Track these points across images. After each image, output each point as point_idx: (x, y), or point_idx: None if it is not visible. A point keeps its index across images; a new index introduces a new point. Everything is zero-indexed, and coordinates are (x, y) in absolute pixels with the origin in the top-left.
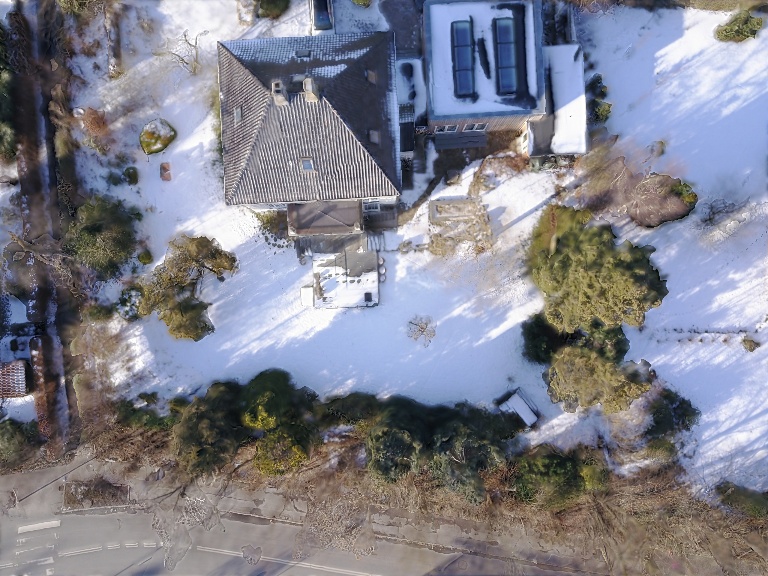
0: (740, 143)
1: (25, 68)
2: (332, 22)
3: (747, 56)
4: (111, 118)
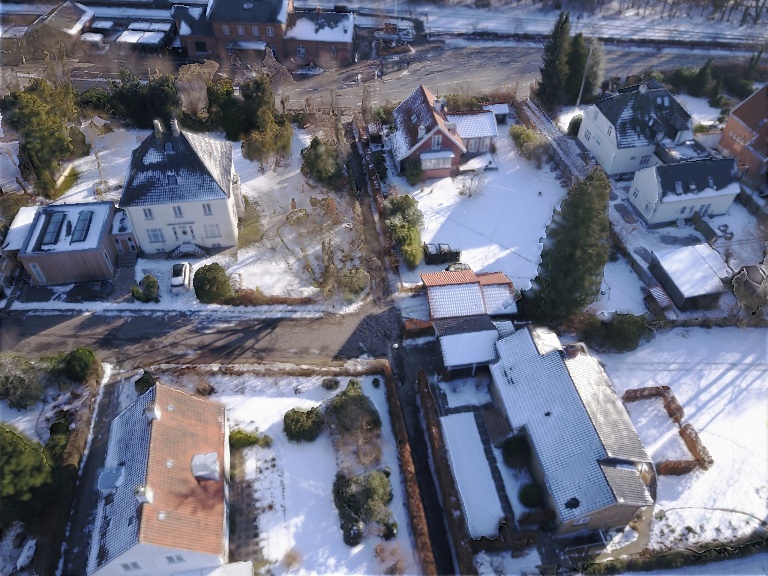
0: None
1: None
2: None
3: None
4: (329, 226)
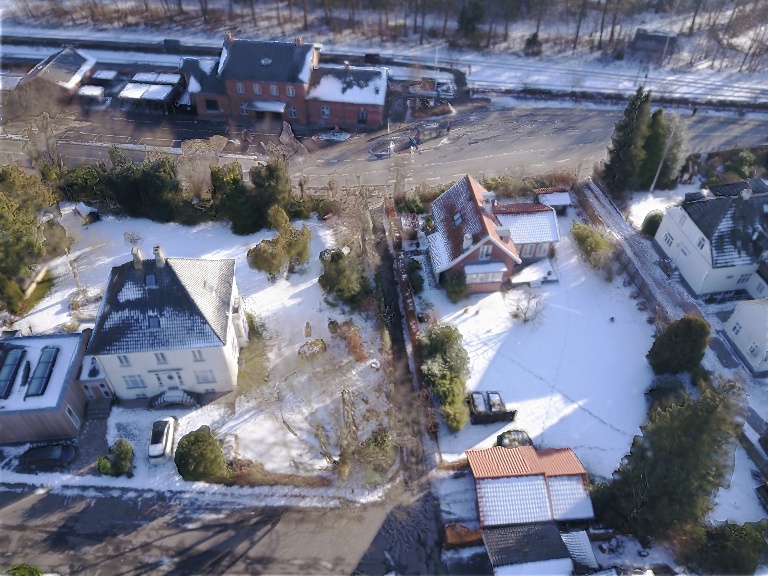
0: None
1: None
2: None
3: None
4: (351, 364)
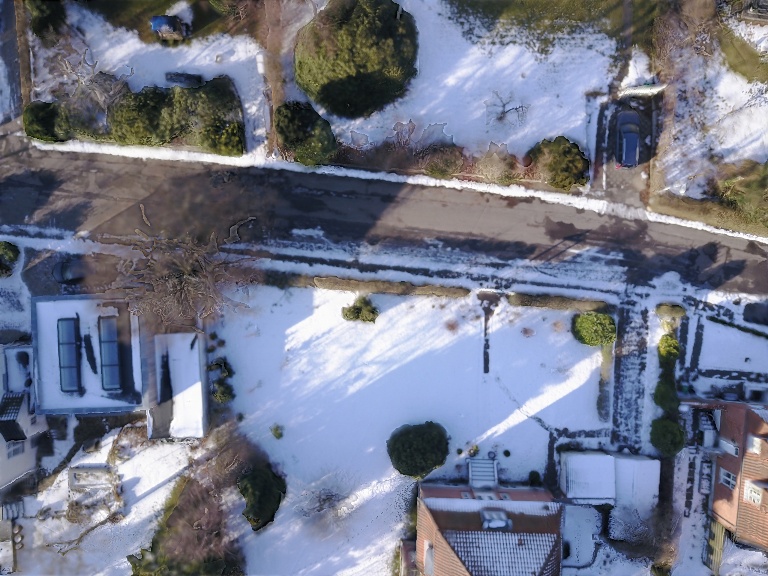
0: (365, 420)
1: None
2: None
3: (373, 335)
4: None
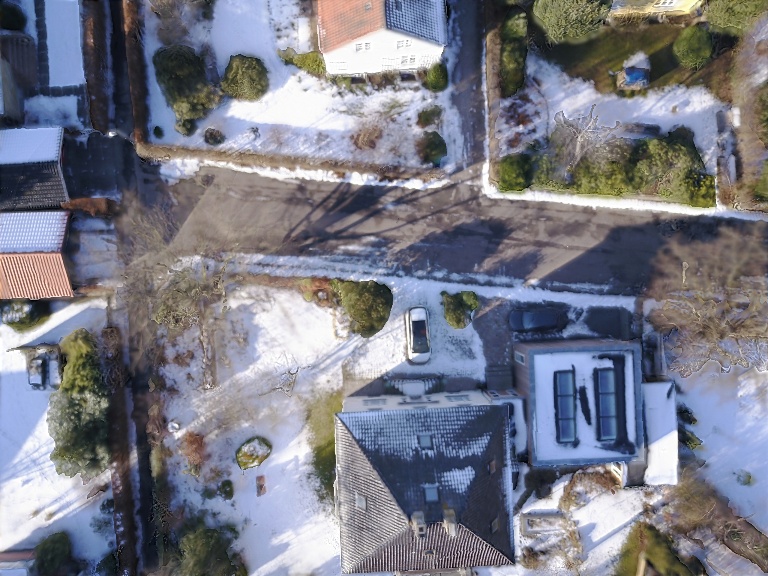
0: None
1: (119, 383)
2: (429, 345)
3: None
4: (206, 431)
